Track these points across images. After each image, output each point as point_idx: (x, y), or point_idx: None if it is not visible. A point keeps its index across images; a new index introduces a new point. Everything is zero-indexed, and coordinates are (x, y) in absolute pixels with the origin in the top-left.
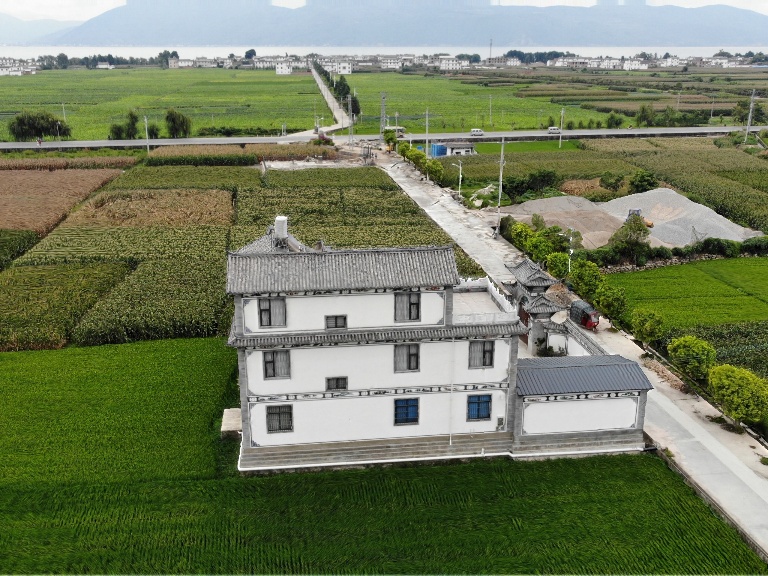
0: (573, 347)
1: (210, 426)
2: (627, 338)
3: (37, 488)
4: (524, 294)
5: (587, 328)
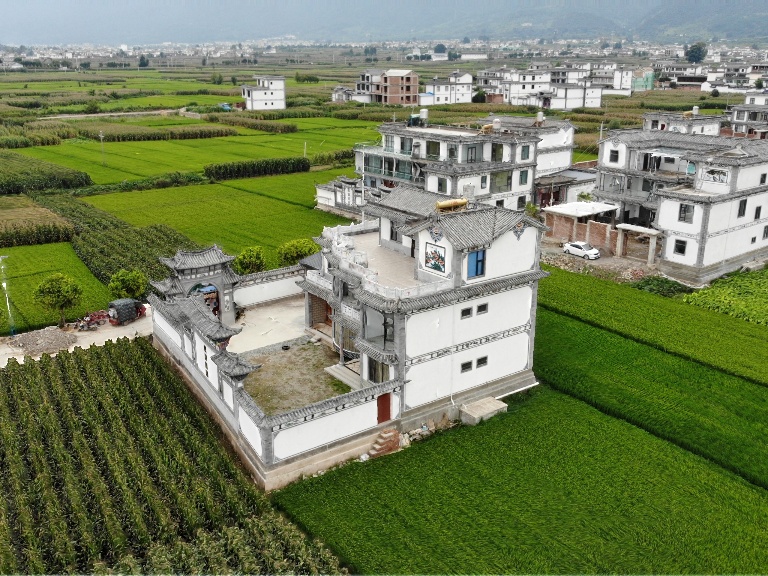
0: (243, 295)
1: None
2: None
3: (689, 441)
4: (199, 281)
5: (141, 316)
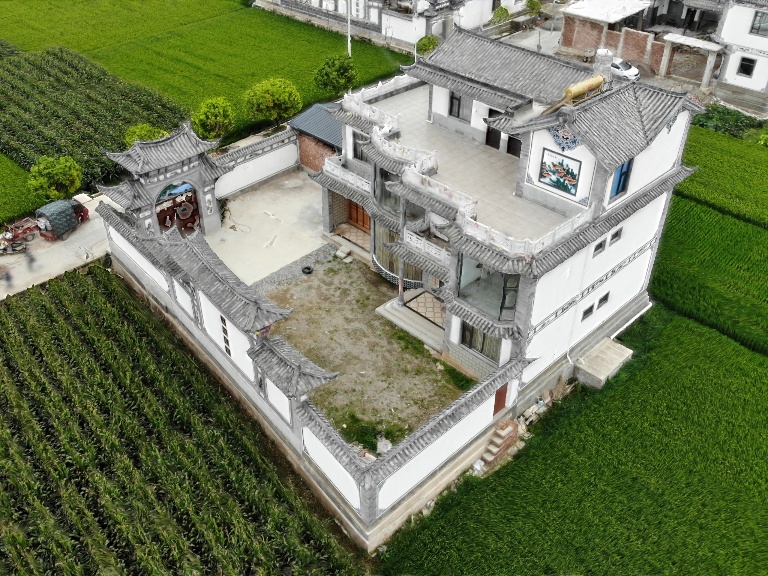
0: (223, 181)
1: (633, 377)
2: (92, 200)
3: None
4: (170, 182)
5: (83, 222)
